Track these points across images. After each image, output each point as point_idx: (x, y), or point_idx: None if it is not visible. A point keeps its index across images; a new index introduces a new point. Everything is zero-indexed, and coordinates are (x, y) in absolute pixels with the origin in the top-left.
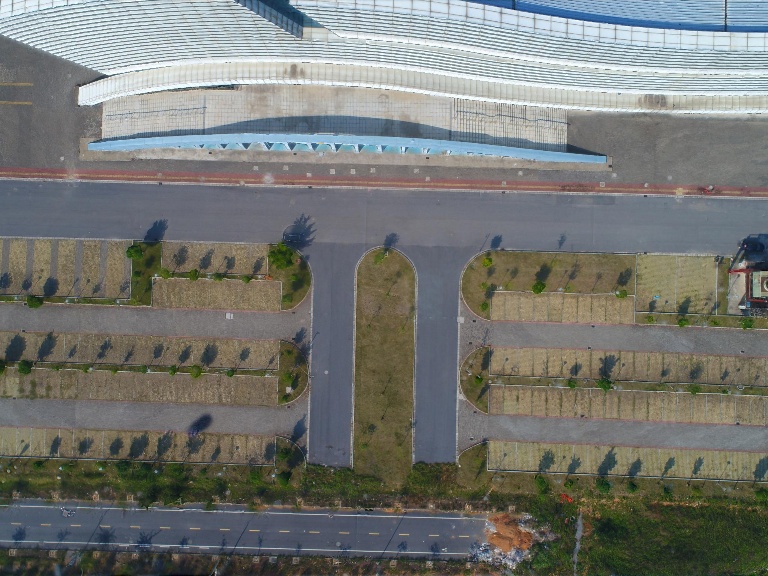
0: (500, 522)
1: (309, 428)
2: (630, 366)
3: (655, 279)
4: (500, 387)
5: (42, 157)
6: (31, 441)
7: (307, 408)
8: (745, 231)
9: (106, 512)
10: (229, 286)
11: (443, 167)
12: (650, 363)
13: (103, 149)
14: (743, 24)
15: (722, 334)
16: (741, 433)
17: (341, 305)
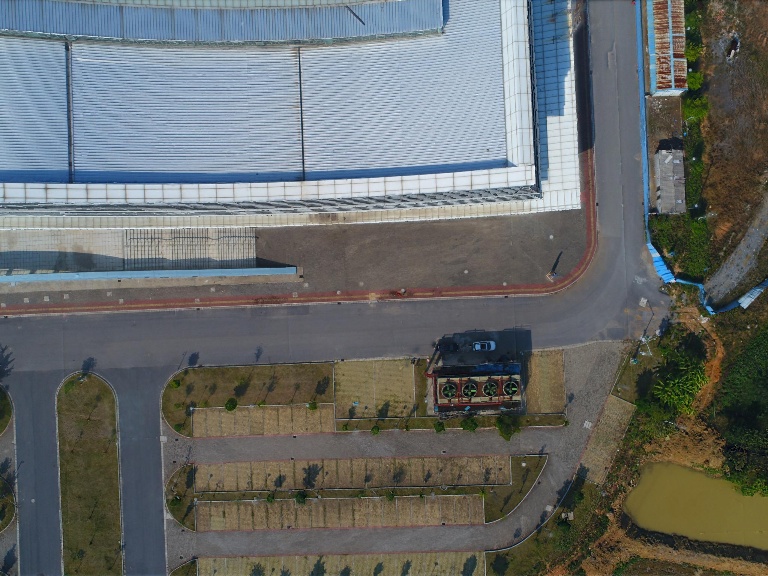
0: None
1: (19, 558)
2: (333, 474)
3: (353, 385)
4: (206, 504)
5: None
6: None
7: (16, 538)
8: (440, 331)
9: None
10: None
11: (135, 289)
12: (353, 470)
13: None
14: (320, 169)
15: (423, 436)
16: (447, 533)
17: (43, 433)
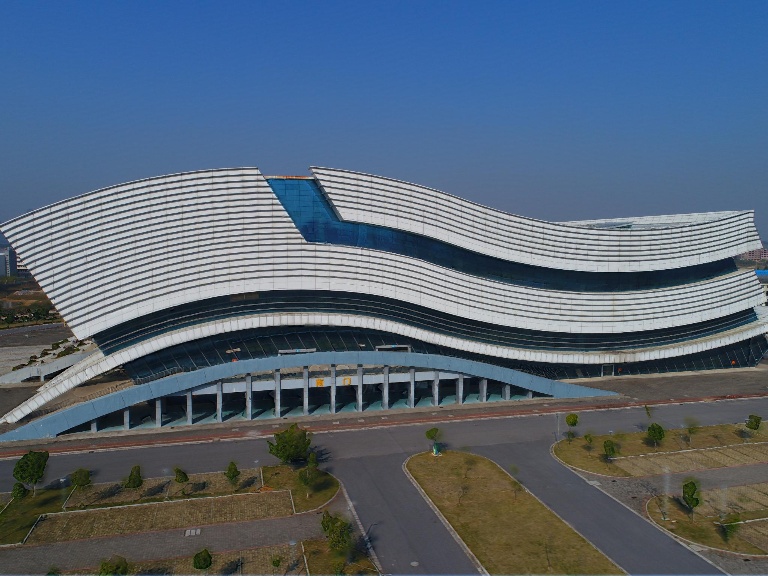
0: None
1: None
2: None
3: None
4: (740, 526)
5: None
6: None
7: None
8: None
9: None
10: (194, 505)
11: (462, 409)
12: None
13: (14, 438)
14: None
15: None
16: None
17: (399, 496)
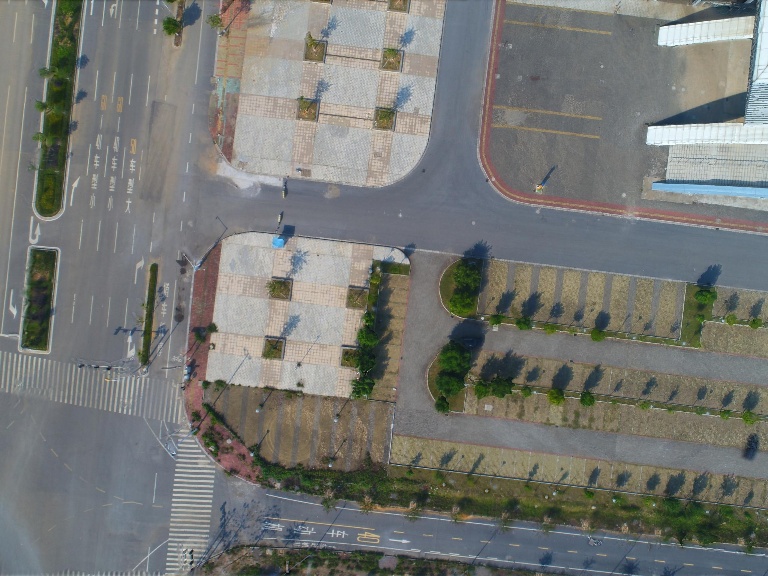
0: None
1: None
2: None
3: None
4: None
5: (604, 192)
6: (571, 470)
7: None
8: None
9: (635, 545)
10: None
11: None
12: None
13: (668, 190)
14: None
15: None
16: None
17: None
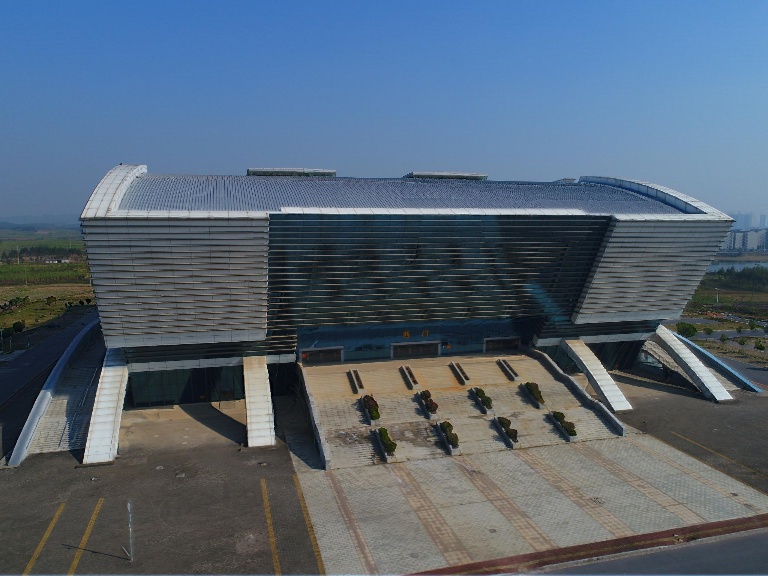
0: (709, 315)
1: None
2: None
3: None
4: None
5: None
6: None
7: (759, 336)
8: None
9: None
10: None
11: None
12: None
13: None
14: None
15: None
16: None
17: None
